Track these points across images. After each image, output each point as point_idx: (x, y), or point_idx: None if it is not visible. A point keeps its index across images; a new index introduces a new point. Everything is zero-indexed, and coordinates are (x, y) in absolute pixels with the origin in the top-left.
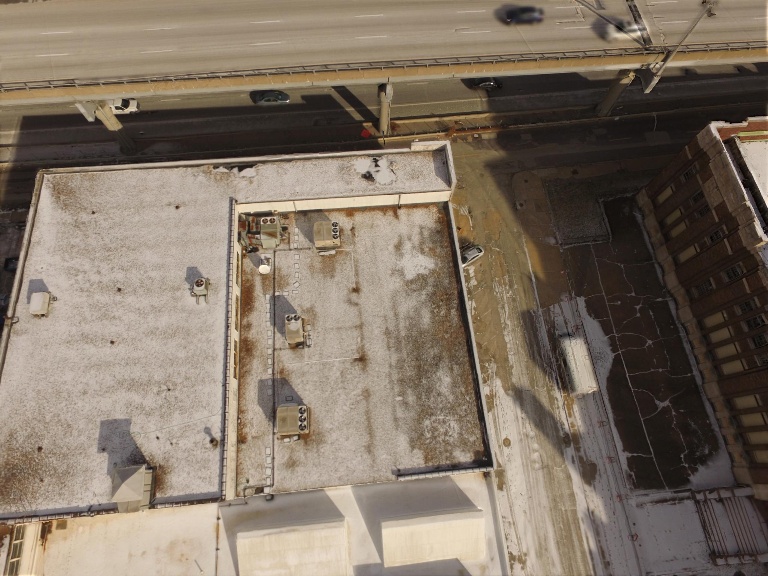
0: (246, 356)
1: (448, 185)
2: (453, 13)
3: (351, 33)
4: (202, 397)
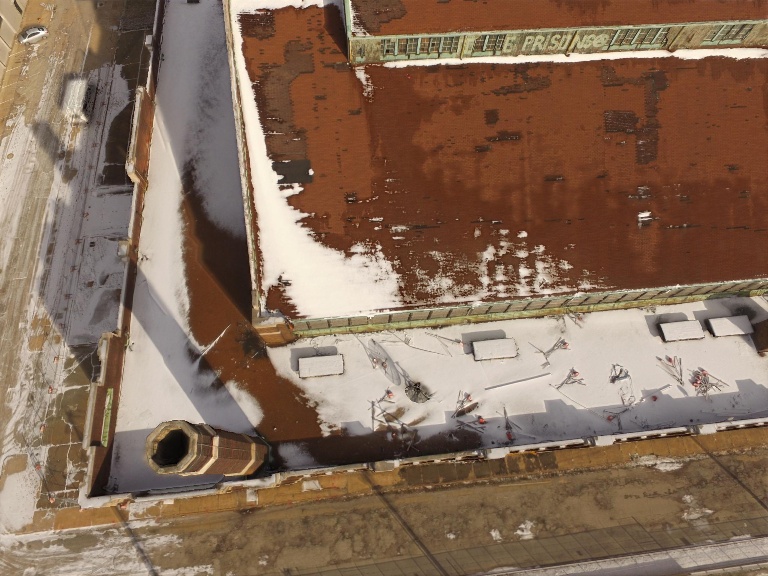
0: None
1: None
2: None
3: None
4: None
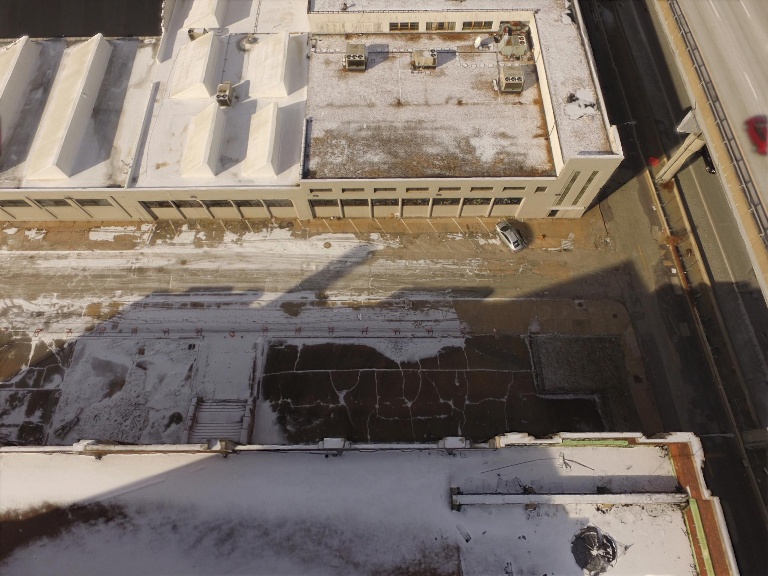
0: (408, 38)
1: None
2: None
3: (751, 69)
4: (376, 2)
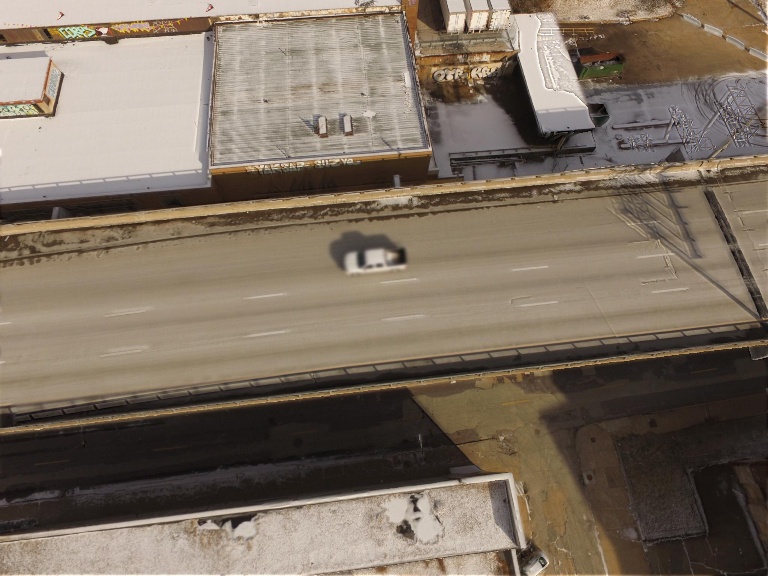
0: None
1: (513, 541)
2: (507, 272)
3: (376, 312)
4: None
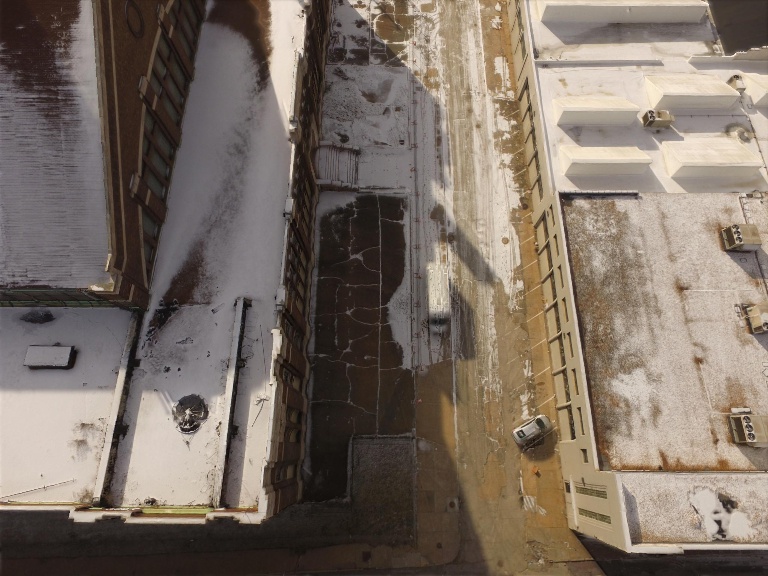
0: None
1: None
2: None
3: None
4: None
